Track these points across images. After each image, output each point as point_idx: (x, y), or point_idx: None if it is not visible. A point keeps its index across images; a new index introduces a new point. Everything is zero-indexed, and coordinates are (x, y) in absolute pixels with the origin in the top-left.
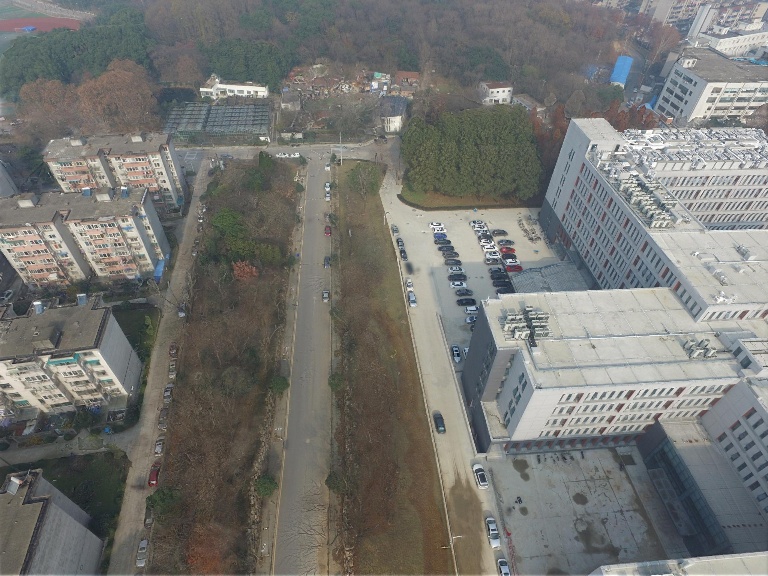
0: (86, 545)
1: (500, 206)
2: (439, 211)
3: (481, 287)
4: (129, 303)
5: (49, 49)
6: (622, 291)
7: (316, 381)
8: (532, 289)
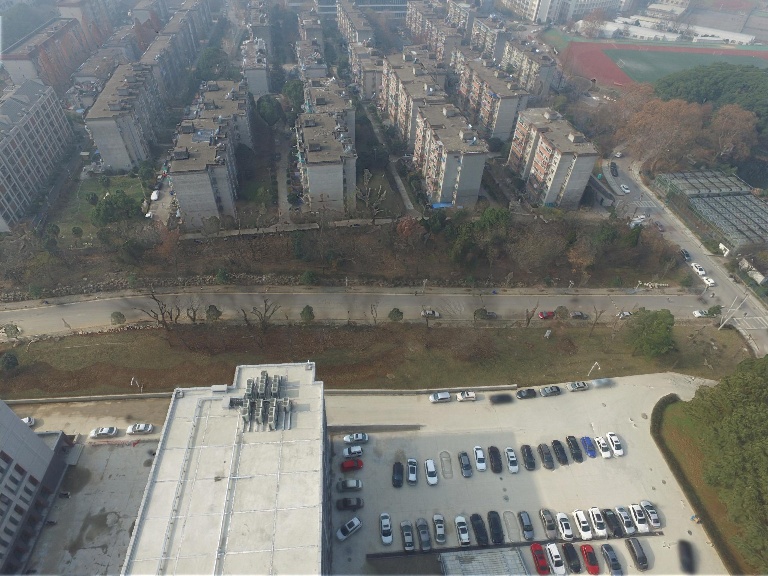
0: (211, 213)
1: (736, 574)
2: (661, 454)
3: (484, 493)
4: (393, 194)
5: (725, 77)
6: (318, 572)
7: (320, 309)
8: (486, 574)
